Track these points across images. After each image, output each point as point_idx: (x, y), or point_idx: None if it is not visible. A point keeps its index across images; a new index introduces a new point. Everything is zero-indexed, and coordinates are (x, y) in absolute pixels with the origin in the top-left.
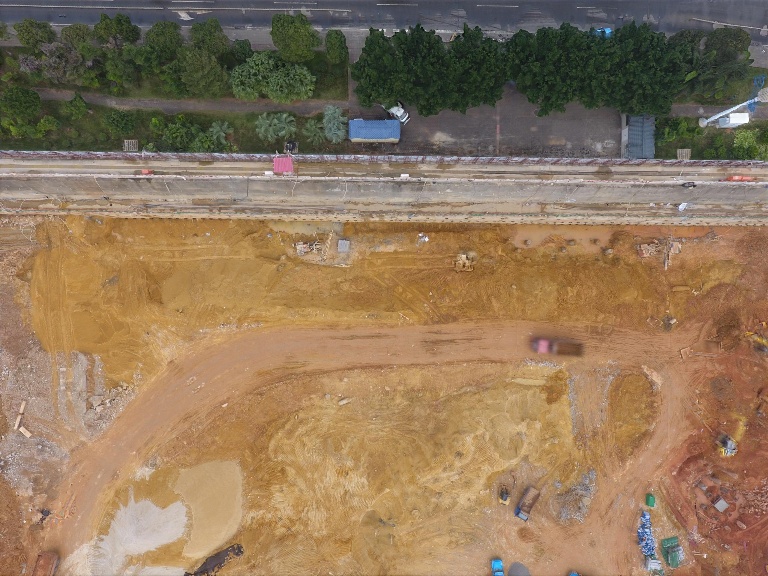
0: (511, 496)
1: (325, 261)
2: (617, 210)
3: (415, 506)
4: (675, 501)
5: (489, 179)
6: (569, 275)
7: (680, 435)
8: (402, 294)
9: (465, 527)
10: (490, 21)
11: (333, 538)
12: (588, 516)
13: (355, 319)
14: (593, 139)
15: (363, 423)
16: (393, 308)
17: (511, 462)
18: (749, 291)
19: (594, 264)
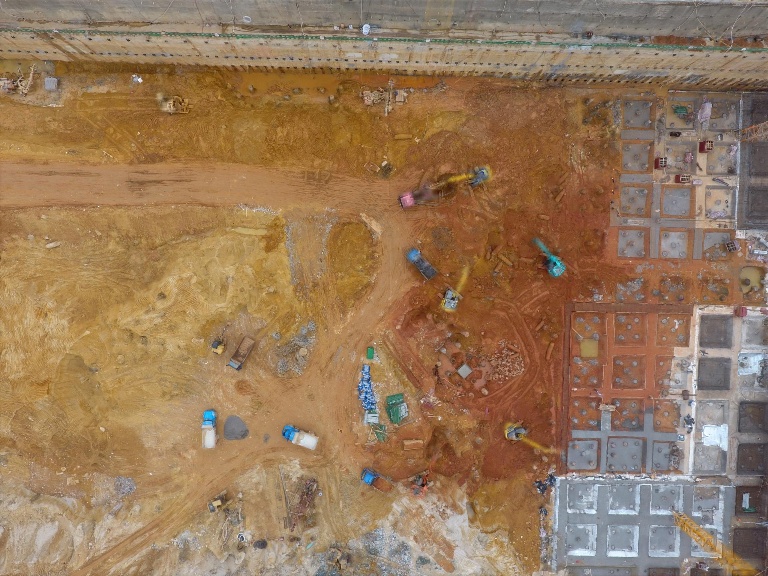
0: (229, 348)
1: (35, 101)
2: (301, 33)
3: (121, 352)
4: (405, 359)
5: None
6: (283, 117)
7: (402, 287)
8: (112, 135)
9: (177, 377)
10: None
11: (29, 380)
12: (307, 369)
13: (54, 154)
14: None
15: (74, 269)
16: (98, 146)
17: (218, 307)
18: (468, 137)
19: (314, 110)
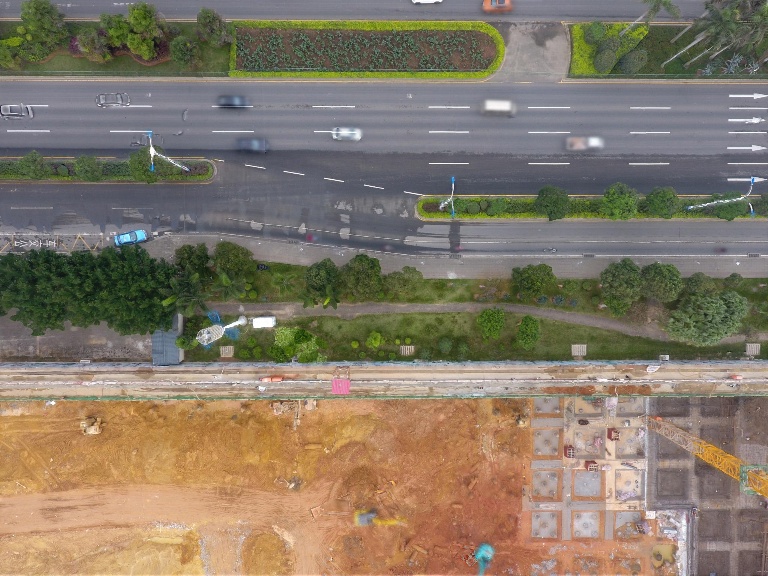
0: None
1: None
2: (199, 391)
3: None
4: None
5: (25, 382)
6: (193, 438)
7: None
8: (26, 459)
9: None
10: (25, 223)
11: None
12: None
13: None
14: (134, 338)
15: None
16: (11, 476)
17: None
18: (374, 451)
19: (225, 424)
